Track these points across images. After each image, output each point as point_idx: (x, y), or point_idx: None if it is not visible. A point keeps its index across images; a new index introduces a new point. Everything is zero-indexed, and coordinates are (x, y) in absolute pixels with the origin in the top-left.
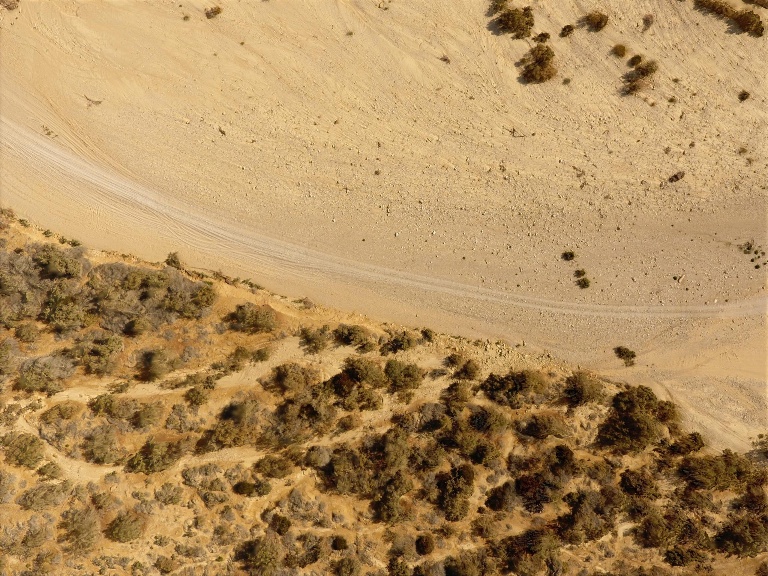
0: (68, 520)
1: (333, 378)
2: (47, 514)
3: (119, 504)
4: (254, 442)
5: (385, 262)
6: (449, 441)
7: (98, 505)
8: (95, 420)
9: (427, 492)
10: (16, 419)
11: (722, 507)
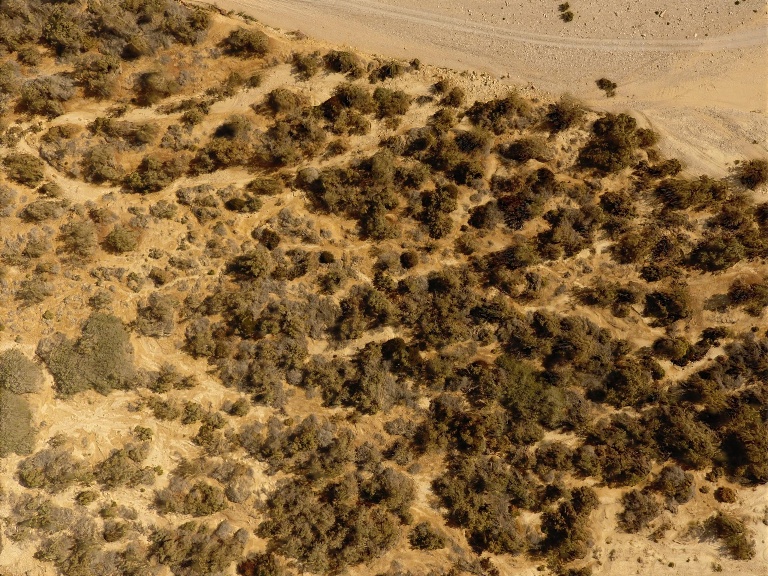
0: (66, 233)
1: (323, 103)
2: (46, 227)
3: (115, 218)
4: (246, 163)
5: None
6: (434, 161)
7: (95, 219)
8: (93, 140)
9: (412, 208)
10: (17, 141)
11: (697, 225)
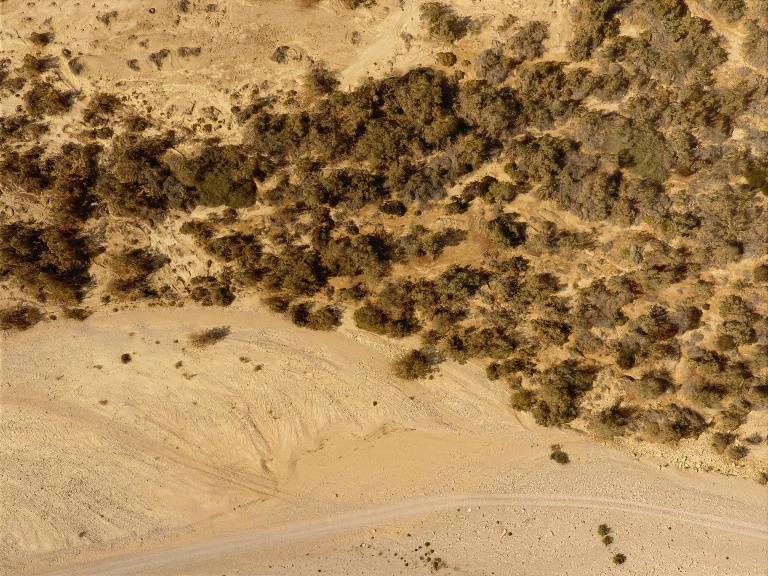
0: None
1: None
2: None
3: None
4: None
5: None
6: (744, 375)
7: None
8: None
9: (765, 326)
10: None
11: (475, 313)
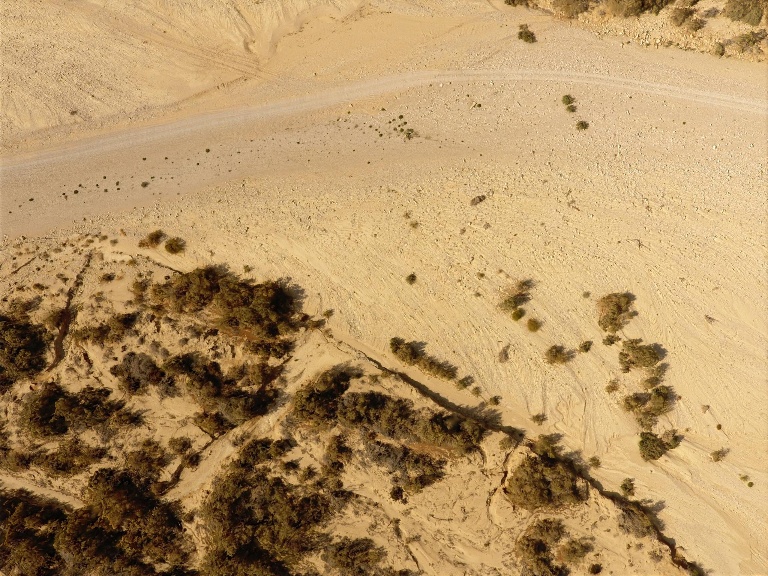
0: None
1: None
2: None
3: None
4: None
5: (763, 119)
6: None
7: None
8: None
9: None
10: None
11: None
